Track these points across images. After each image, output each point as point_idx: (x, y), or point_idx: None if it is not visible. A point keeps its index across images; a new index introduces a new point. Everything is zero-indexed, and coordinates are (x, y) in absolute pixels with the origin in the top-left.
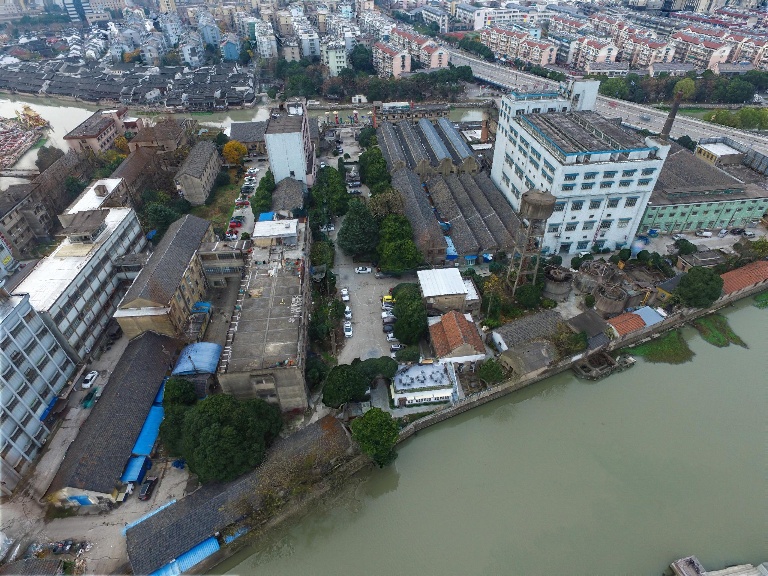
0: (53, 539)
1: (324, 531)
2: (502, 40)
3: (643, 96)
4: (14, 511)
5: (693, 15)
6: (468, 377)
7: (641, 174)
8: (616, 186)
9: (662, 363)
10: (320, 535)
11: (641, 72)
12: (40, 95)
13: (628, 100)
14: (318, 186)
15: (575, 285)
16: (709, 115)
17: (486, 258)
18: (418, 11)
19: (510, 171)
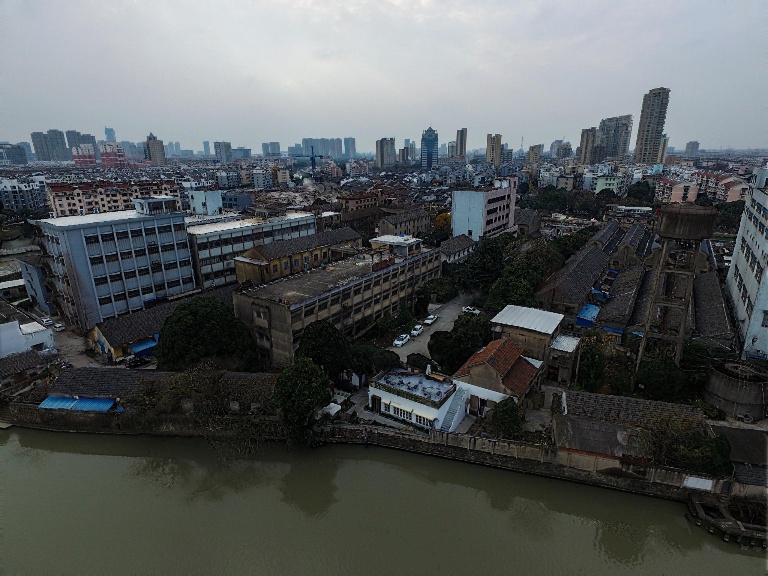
0: (68, 363)
1: None
2: None
3: None
4: (79, 342)
5: None
6: (486, 425)
7: None
8: None
9: None
10: None
11: None
12: None
13: None
14: None
15: None
16: None
17: None
18: None
19: (741, 258)
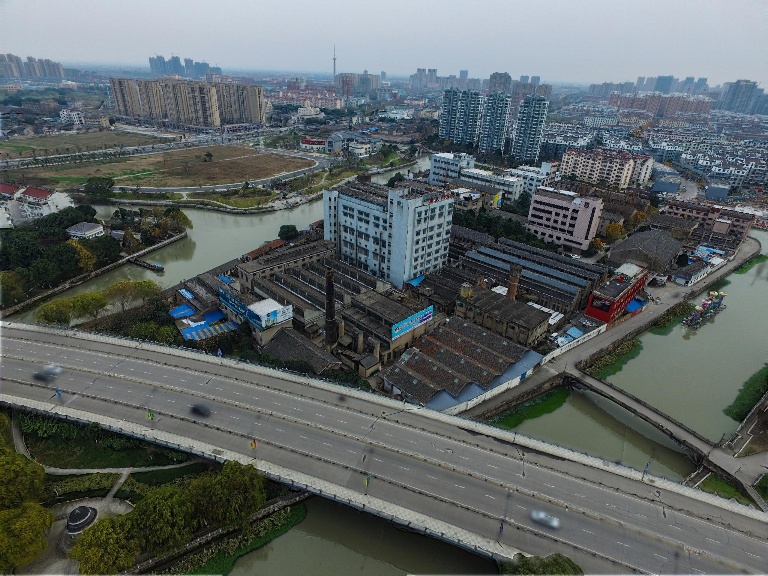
0: None
1: None
2: None
3: None
4: None
5: None
6: None
7: None
8: None
9: None
10: None
11: None
12: None
13: None
14: None
15: None
16: None
17: None
18: None
19: None
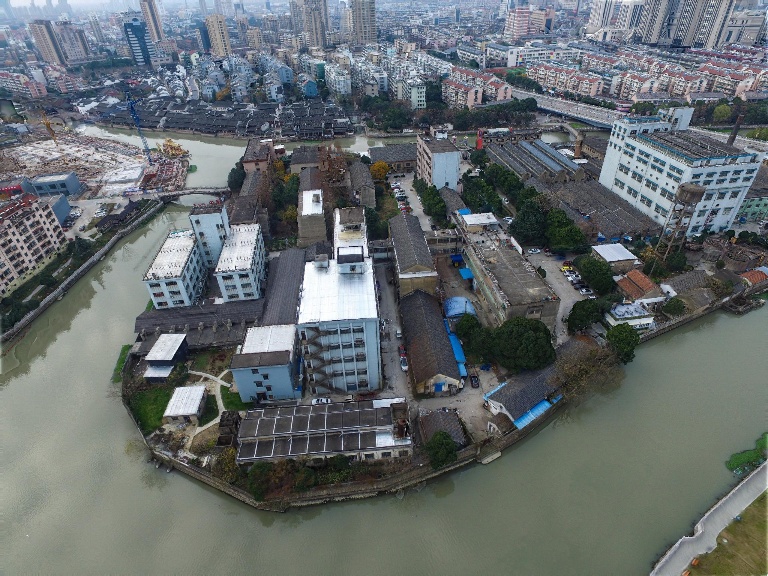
0: (430, 409)
1: (587, 410)
2: (550, 75)
3: None
4: None
5: (707, 51)
6: None
7: (745, 173)
8: (727, 182)
9: None
10: (585, 413)
11: (680, 100)
12: (158, 129)
13: None
14: (468, 193)
15: None
16: (752, 133)
17: (627, 239)
18: (453, 50)
19: (625, 177)
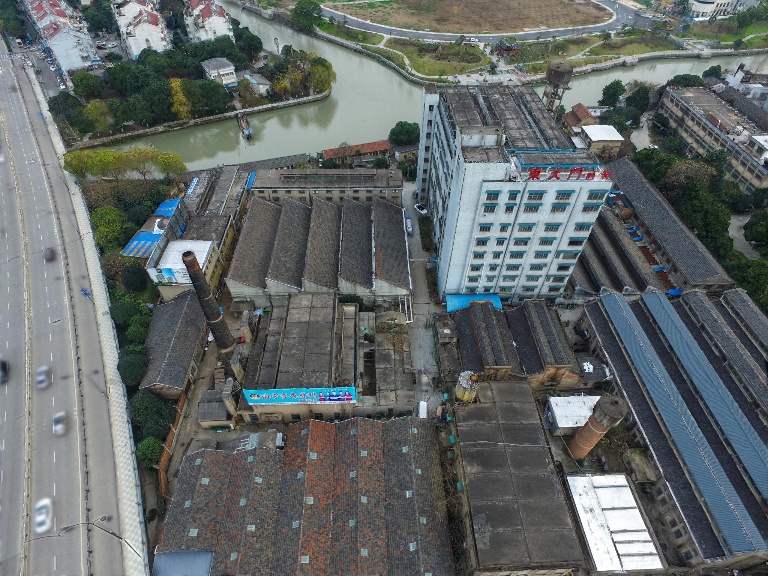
0: None
1: None
2: None
3: None
4: None
5: None
6: None
7: None
8: None
9: None
10: None
11: None
12: None
13: None
14: None
15: None
16: None
17: None
18: None
19: None
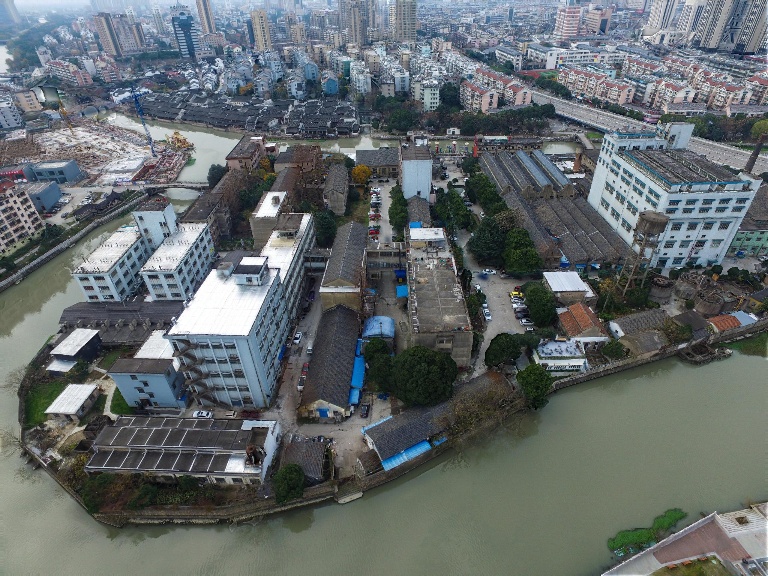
0: (307, 436)
1: (489, 455)
2: (580, 80)
3: (721, 135)
4: (274, 417)
5: (767, 59)
6: (592, 354)
7: (735, 202)
8: (713, 212)
9: (755, 356)
10: (486, 458)
11: (718, 112)
12: (176, 121)
13: (706, 138)
14: (440, 204)
15: (674, 292)
16: None
17: (594, 267)
18: (491, 51)
19: (610, 197)
